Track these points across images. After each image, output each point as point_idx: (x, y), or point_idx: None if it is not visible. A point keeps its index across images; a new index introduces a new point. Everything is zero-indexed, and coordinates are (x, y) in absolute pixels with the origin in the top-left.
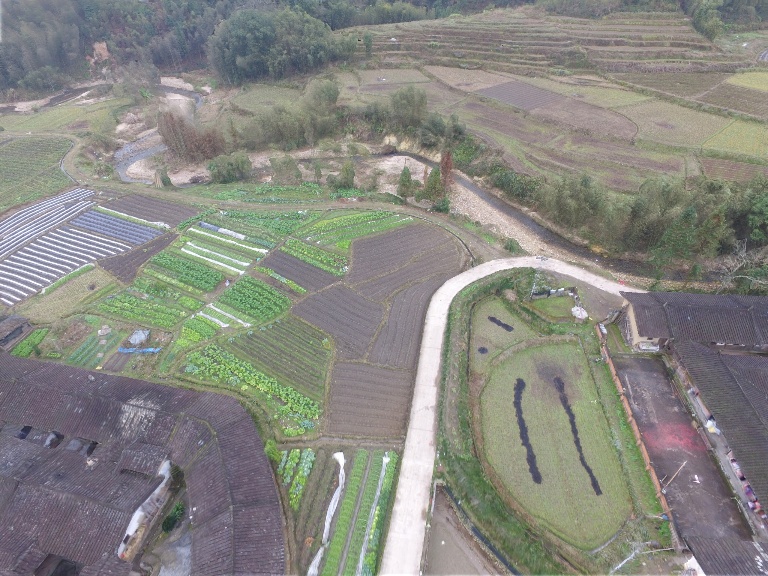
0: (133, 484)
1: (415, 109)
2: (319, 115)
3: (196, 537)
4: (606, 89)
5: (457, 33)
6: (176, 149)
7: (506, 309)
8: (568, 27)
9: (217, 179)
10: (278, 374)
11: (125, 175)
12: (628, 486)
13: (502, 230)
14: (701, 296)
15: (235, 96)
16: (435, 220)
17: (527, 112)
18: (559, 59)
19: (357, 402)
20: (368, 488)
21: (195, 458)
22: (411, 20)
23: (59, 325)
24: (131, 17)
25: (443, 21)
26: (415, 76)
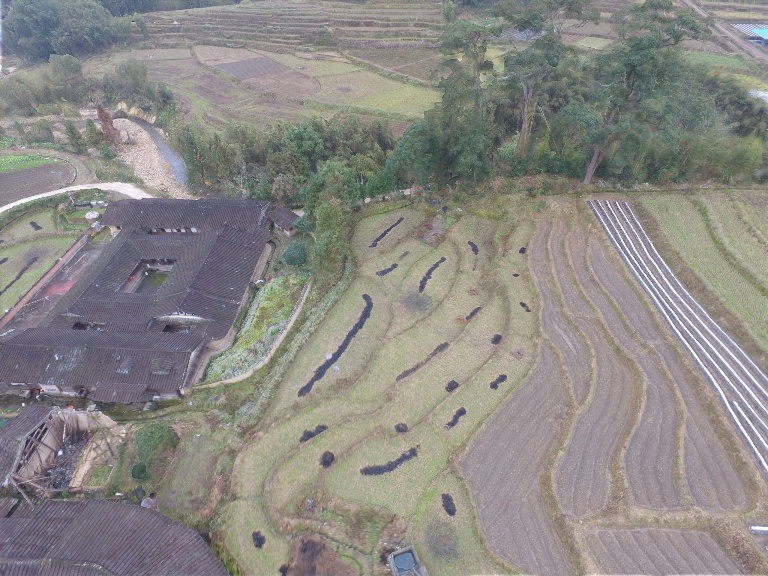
0: None
1: (138, 79)
2: (52, 84)
3: None
4: (332, 62)
5: (232, 17)
6: None
7: (51, 217)
8: (332, 11)
9: None
10: None
11: None
12: None
13: (145, 171)
14: None
15: None
16: (73, 161)
17: (240, 81)
18: (310, 38)
19: None
20: None
21: None
22: (208, 6)
23: None
24: None
25: (228, 6)
26: (181, 54)
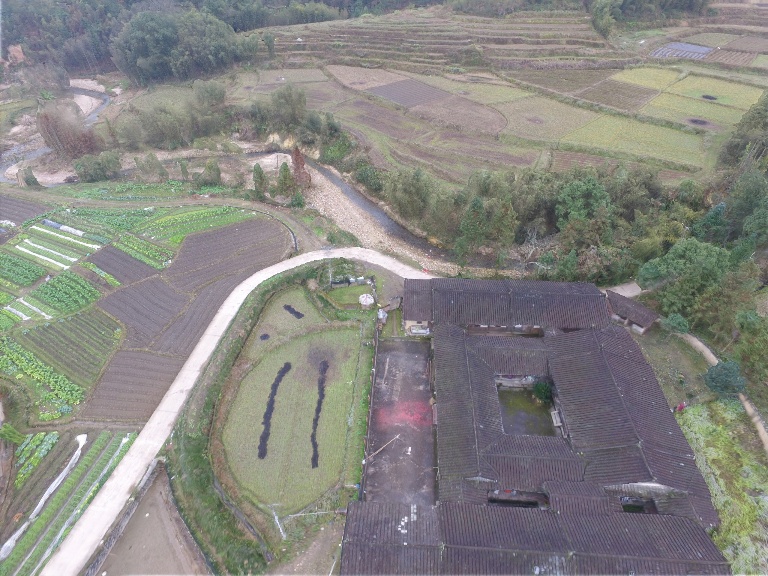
0: None
1: (296, 108)
2: (200, 114)
3: None
4: (494, 86)
5: (361, 33)
6: (56, 150)
7: (304, 298)
8: (471, 26)
9: (84, 178)
10: (58, 363)
11: (3, 176)
12: (343, 459)
13: (350, 224)
14: (477, 281)
15: (136, 97)
16: (276, 215)
17: (407, 109)
18: (456, 57)
19: (122, 387)
20: (95, 467)
21: None
22: (324, 20)
23: None
24: (45, 20)
25: (351, 21)
26: (315, 75)
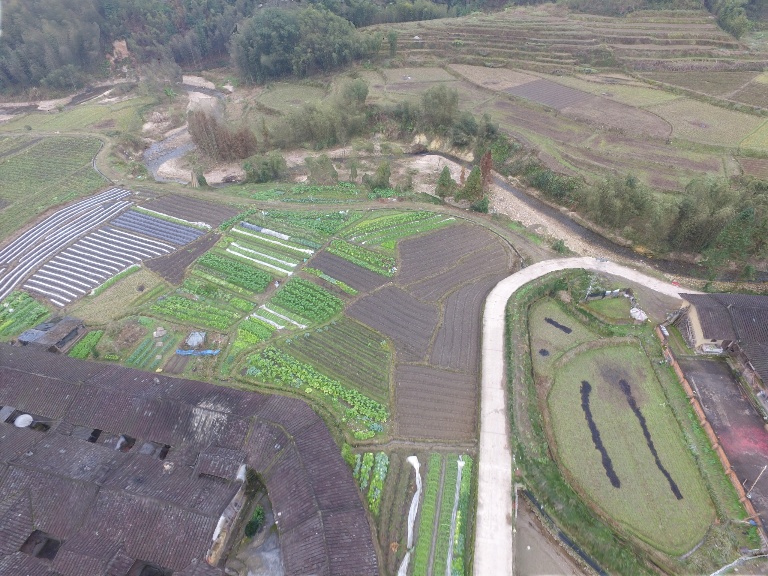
0: (213, 488)
1: (446, 108)
2: (350, 114)
3: (285, 543)
4: (635, 88)
5: (481, 31)
6: (207, 148)
7: (562, 310)
8: (592, 25)
9: (252, 179)
10: (340, 376)
11: (157, 175)
12: (709, 490)
13: None
14: (762, 298)
15: (260, 95)
16: (478, 220)
17: (558, 111)
18: (585, 57)
19: (424, 405)
20: (447, 492)
21: (273, 462)
22: (432, 18)
23: (114, 327)
24: (151, 15)
25: (466, 19)
26: (440, 75)
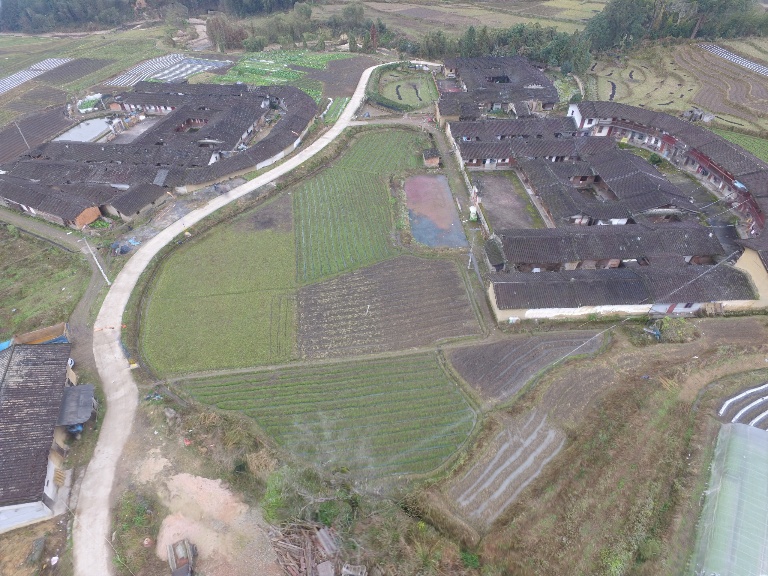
0: None
1: (357, 17)
2: (301, 21)
3: None
4: (471, 9)
5: None
6: (219, 41)
7: (397, 73)
8: None
9: (249, 50)
10: None
11: None
12: None
13: None
14: None
15: (244, 22)
16: (368, 55)
17: (422, 19)
18: None
19: (335, 91)
20: None
21: None
22: None
23: None
24: None
25: None
26: None
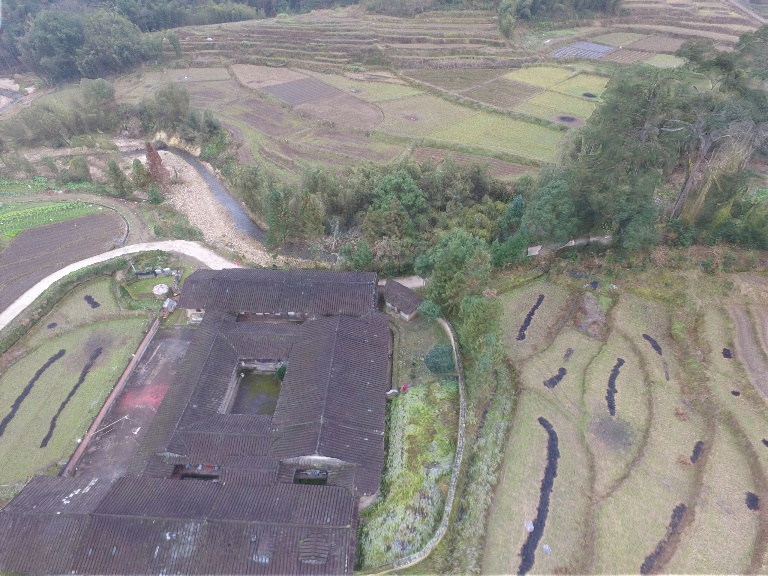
0: None
1: (180, 106)
2: (84, 112)
3: None
4: (388, 85)
5: (270, 32)
6: None
7: (108, 288)
8: (379, 26)
9: None
10: None
11: None
12: None
13: (201, 218)
14: (264, 271)
15: (40, 96)
16: (121, 209)
17: (292, 107)
18: (359, 56)
19: None
20: None
21: None
22: (241, 20)
23: None
24: None
25: (264, 21)
26: (218, 74)
